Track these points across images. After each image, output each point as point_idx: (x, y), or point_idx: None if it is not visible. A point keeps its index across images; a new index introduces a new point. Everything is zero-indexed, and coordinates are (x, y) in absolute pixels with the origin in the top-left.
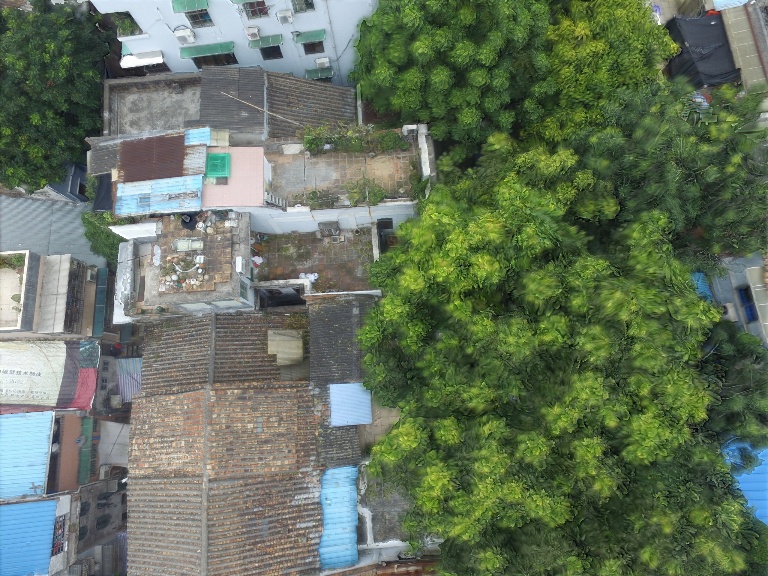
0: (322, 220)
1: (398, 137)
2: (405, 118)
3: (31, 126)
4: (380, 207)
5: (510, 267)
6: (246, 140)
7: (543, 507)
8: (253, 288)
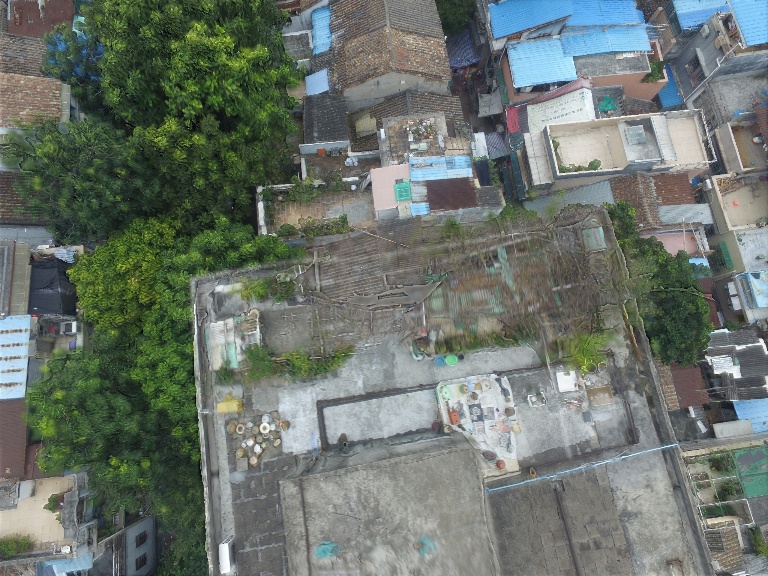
0: None
1: (280, 229)
2: None
3: None
4: None
5: None
6: None
7: None
8: None
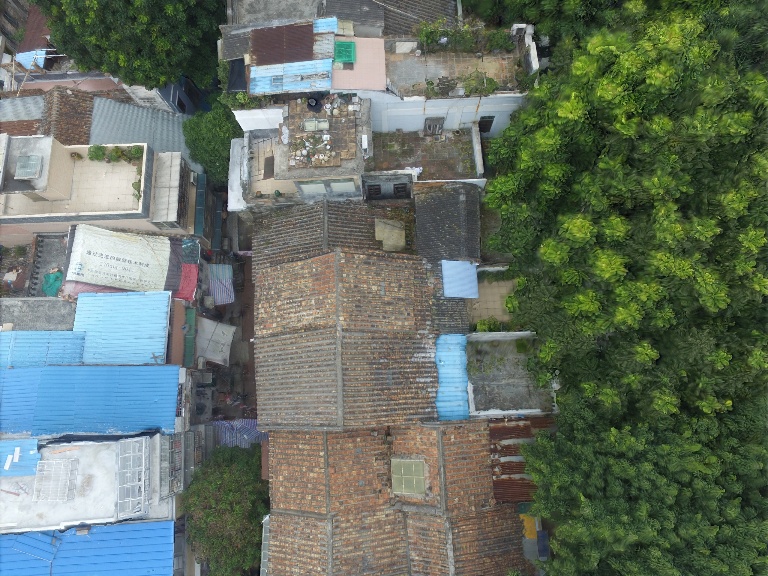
0: (430, 115)
1: (508, 35)
2: (506, 26)
3: (162, 18)
4: (490, 99)
5: (679, 82)
6: (364, 35)
7: (706, 288)
8: (362, 179)
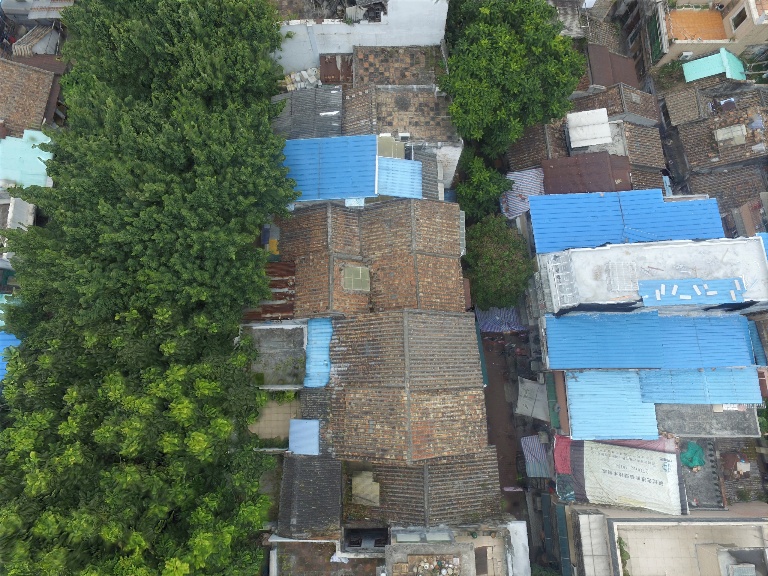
0: None
1: None
2: None
3: None
4: None
5: None
6: None
7: (115, 389)
8: None
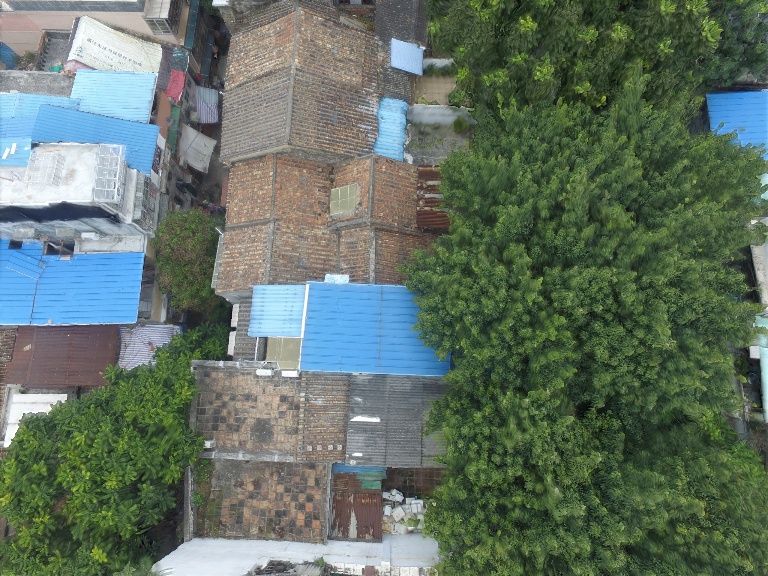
0: None
1: None
2: None
3: None
4: None
5: None
6: None
7: None
8: None
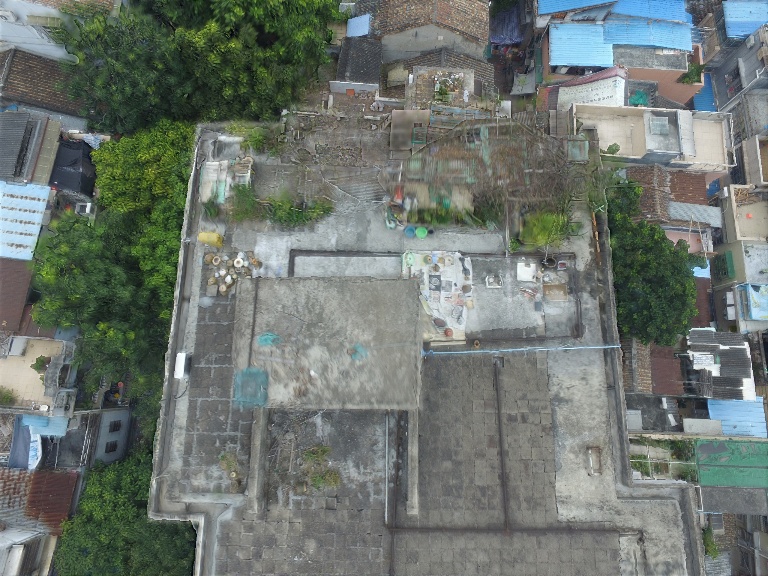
0: None
1: None
2: None
3: None
4: None
5: None
6: None
7: None
8: None
